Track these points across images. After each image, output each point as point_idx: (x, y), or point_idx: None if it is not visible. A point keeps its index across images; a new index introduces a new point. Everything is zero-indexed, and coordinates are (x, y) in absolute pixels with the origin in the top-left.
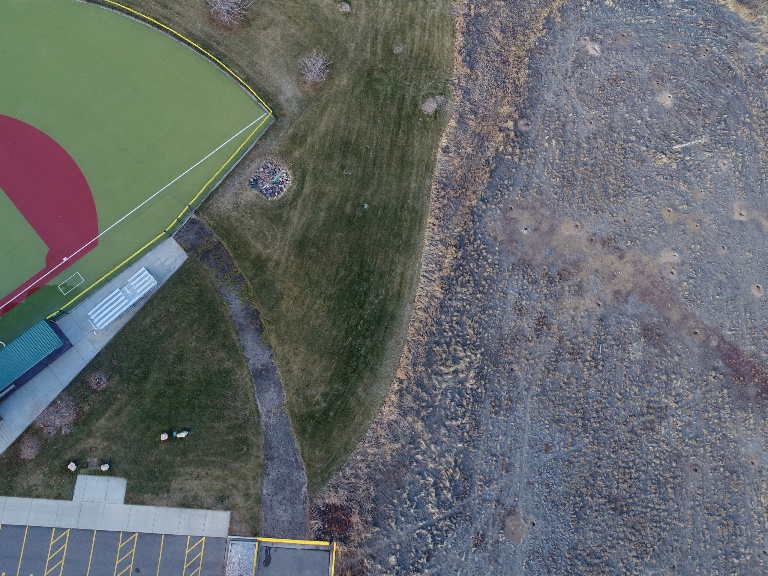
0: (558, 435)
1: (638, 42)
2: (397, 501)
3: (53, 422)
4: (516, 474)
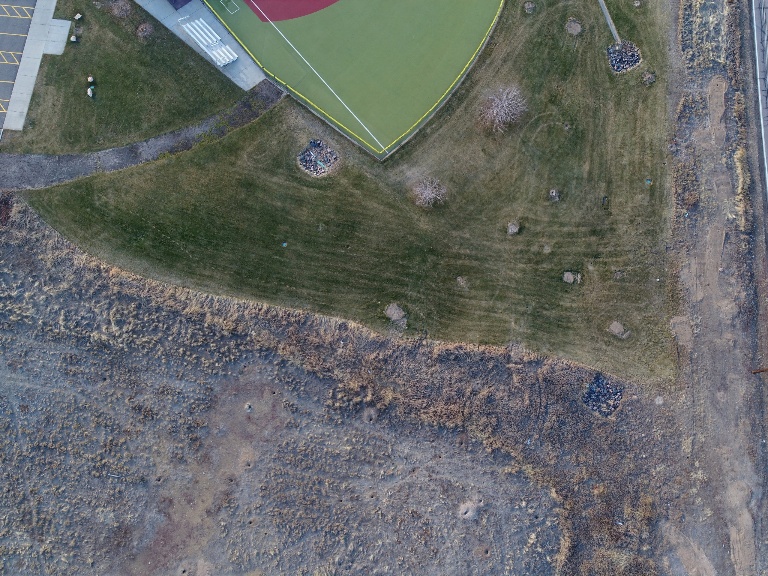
0: (34, 419)
1: (478, 571)
2: (3, 263)
3: (116, 1)
4: (5, 374)
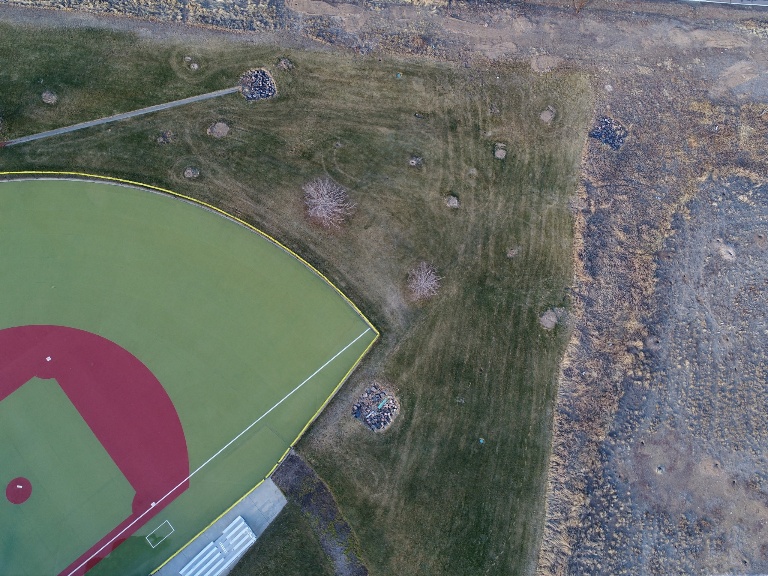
0: None
1: None
2: None
3: None
4: None
